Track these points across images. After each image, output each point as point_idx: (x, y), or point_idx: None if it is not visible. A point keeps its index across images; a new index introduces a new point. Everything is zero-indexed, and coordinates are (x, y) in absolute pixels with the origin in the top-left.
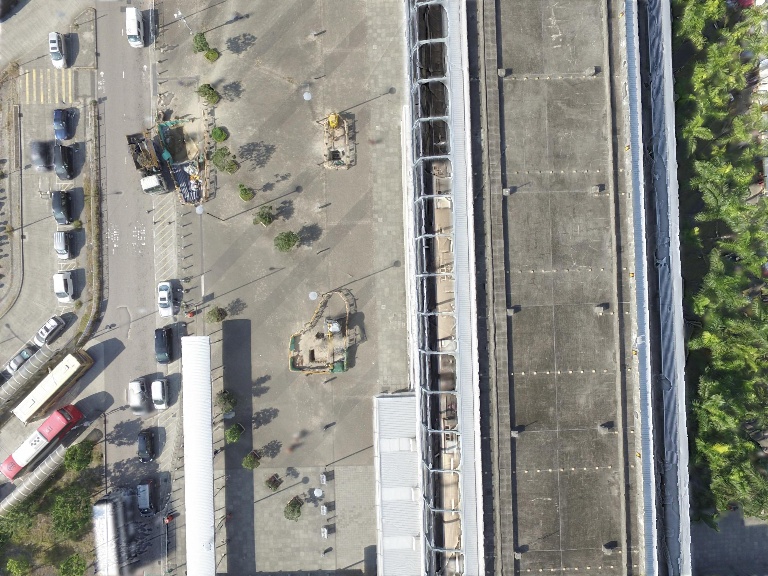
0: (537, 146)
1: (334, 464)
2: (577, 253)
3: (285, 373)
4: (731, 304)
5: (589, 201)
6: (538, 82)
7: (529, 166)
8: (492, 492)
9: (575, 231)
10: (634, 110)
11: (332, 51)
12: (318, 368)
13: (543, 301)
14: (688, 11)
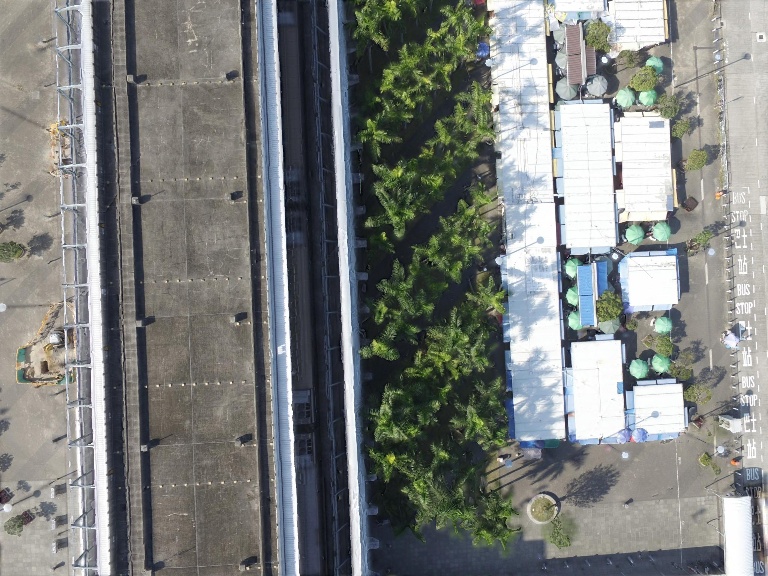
0: (172, 153)
1: (66, 477)
2: (214, 262)
3: (16, 385)
4: (408, 311)
5: (226, 209)
6: (173, 88)
7: (164, 174)
8: (126, 508)
9: (211, 239)
10: (273, 115)
11: (62, 58)
12: (48, 380)
13: (178, 311)
14: (357, 13)
